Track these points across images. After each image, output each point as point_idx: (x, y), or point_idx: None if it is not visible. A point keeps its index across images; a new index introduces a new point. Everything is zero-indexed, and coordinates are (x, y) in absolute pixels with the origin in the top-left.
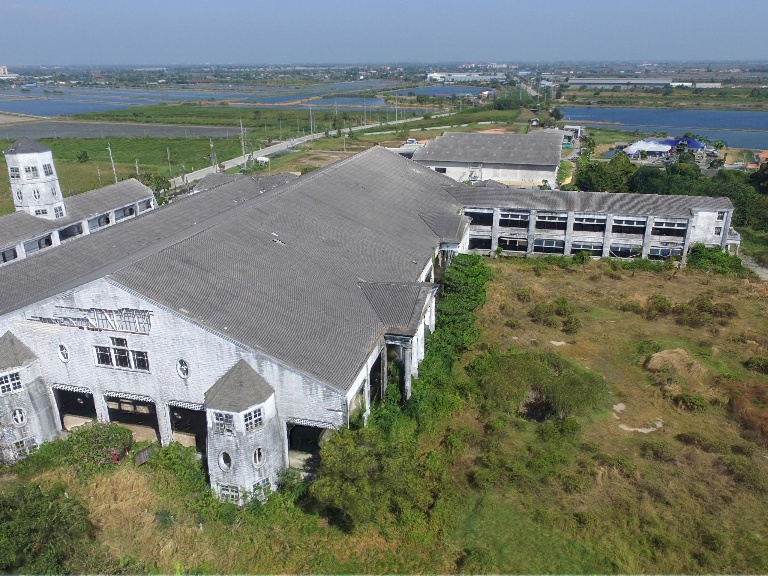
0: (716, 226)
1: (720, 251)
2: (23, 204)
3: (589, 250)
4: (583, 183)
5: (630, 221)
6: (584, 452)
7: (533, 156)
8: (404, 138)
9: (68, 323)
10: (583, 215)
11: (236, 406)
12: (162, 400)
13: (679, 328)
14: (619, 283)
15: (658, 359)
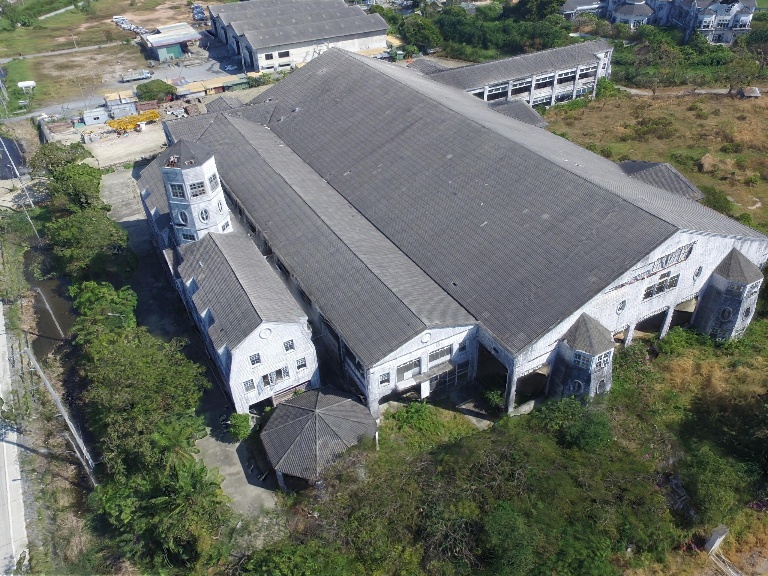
0: (604, 63)
1: (606, 81)
2: (209, 225)
3: (543, 103)
4: (420, 42)
5: (567, 73)
6: (766, 228)
7: (361, 23)
8: (99, 16)
9: (632, 281)
10: (541, 76)
11: (760, 275)
12: (675, 304)
13: (665, 142)
14: (585, 122)
15: (707, 164)
